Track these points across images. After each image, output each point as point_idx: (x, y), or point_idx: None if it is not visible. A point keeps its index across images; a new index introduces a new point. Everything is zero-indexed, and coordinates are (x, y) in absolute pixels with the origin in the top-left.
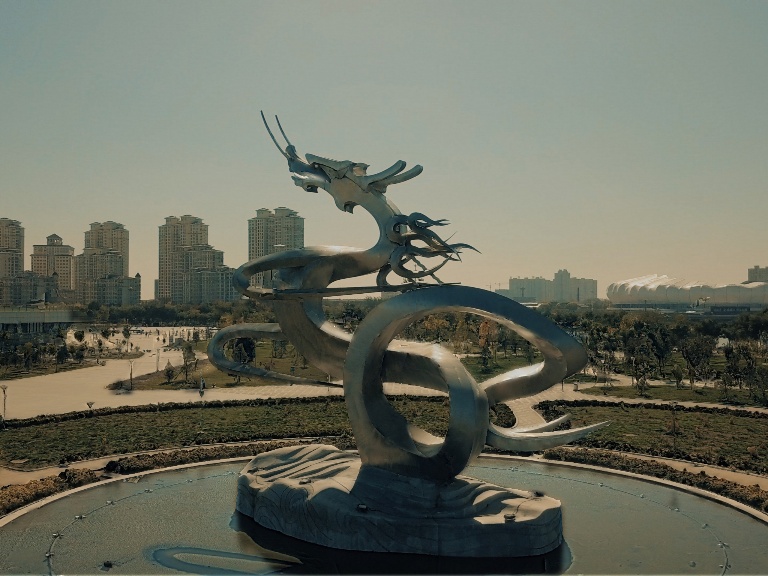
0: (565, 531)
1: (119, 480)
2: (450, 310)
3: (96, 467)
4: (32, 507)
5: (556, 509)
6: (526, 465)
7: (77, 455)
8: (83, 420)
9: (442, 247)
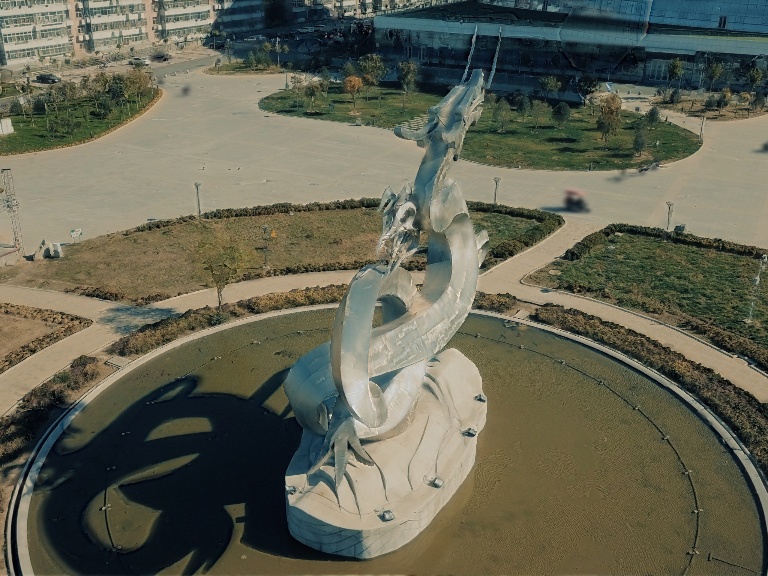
0: (389, 567)
1: (503, 319)
2: None
3: (547, 302)
4: None
5: (318, 519)
6: (739, 571)
7: (579, 287)
8: (741, 258)
9: None
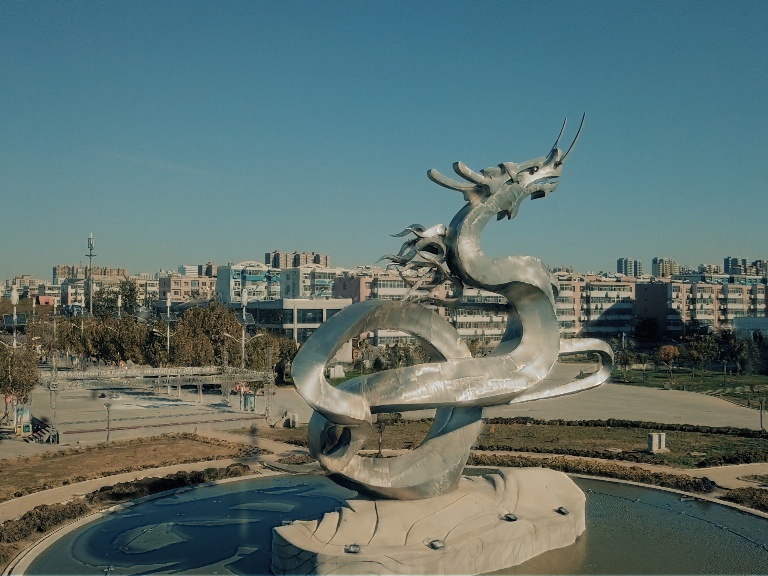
0: None
1: (681, 494)
2: None
3: None
4: (575, 475)
5: None
6: None
7: None
8: None
9: None
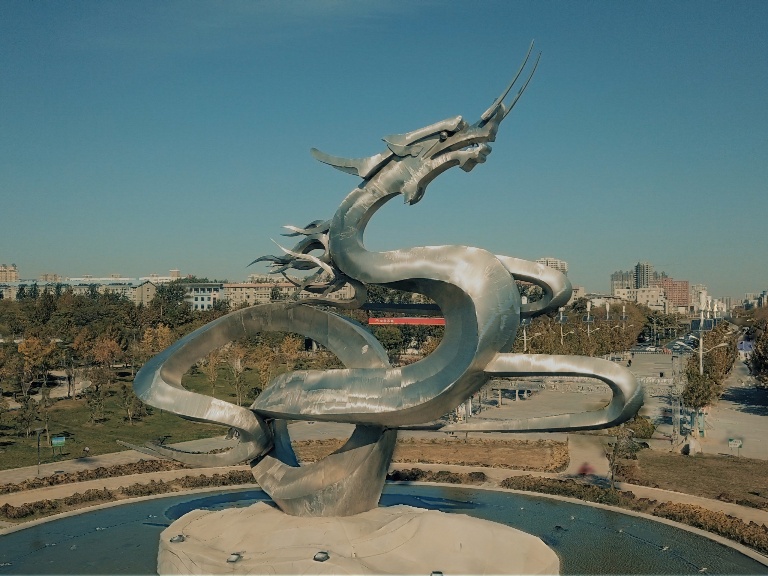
0: None
1: None
2: (281, 329)
3: None
4: None
5: None
6: None
7: None
8: None
9: (288, 260)
